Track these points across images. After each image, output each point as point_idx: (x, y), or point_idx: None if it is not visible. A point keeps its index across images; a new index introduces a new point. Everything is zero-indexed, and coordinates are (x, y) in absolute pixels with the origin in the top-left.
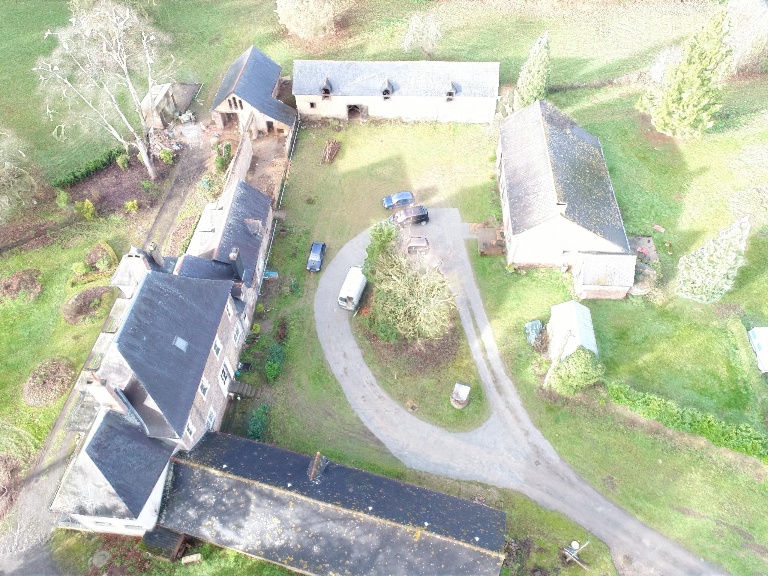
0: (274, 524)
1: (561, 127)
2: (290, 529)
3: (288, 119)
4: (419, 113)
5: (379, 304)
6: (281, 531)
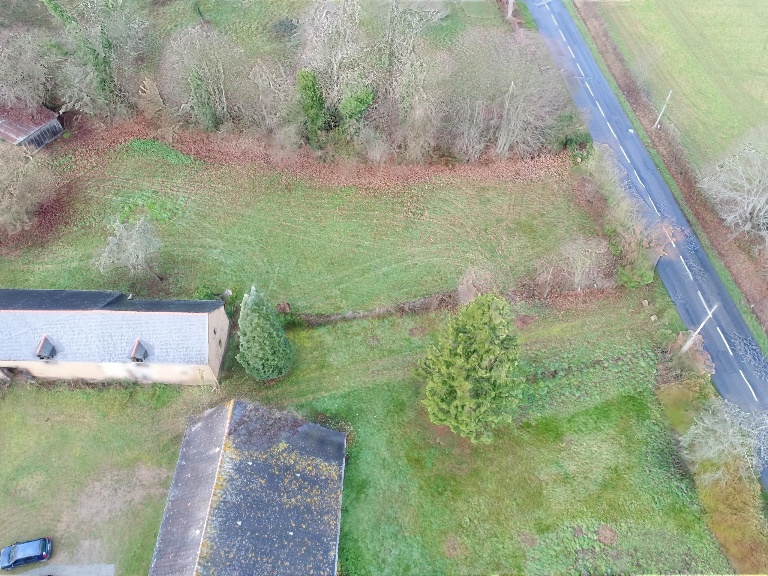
0: None
1: (266, 445)
2: None
3: None
4: (106, 375)
5: None
6: None
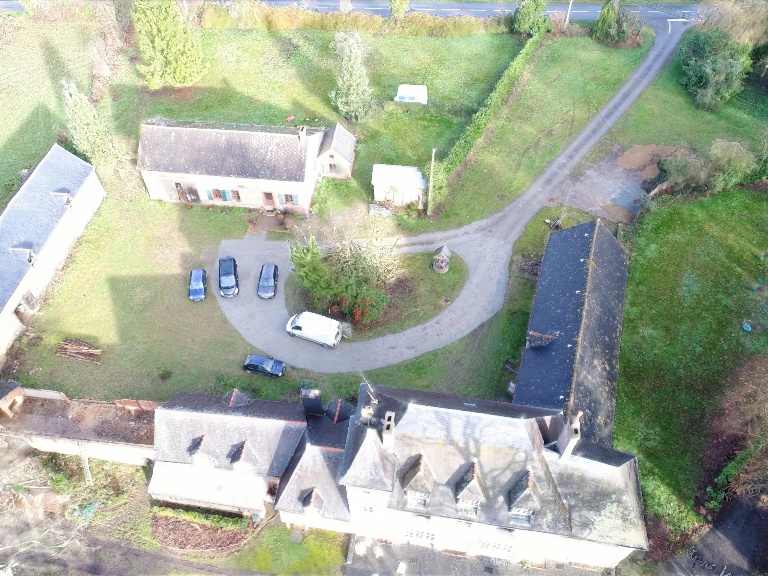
0: (597, 365)
1: None
2: (599, 353)
3: (2, 387)
4: (63, 247)
5: (363, 290)
6: (601, 361)
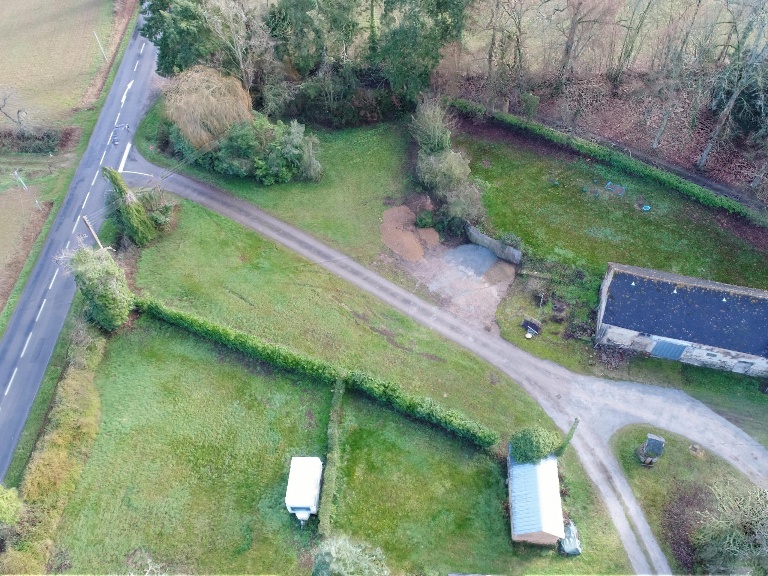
0: None
1: None
2: None
3: None
4: None
5: None
6: None
